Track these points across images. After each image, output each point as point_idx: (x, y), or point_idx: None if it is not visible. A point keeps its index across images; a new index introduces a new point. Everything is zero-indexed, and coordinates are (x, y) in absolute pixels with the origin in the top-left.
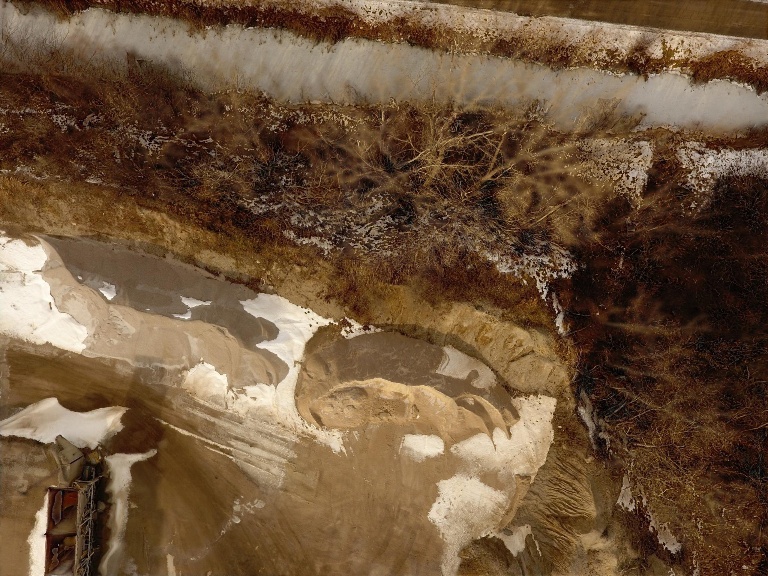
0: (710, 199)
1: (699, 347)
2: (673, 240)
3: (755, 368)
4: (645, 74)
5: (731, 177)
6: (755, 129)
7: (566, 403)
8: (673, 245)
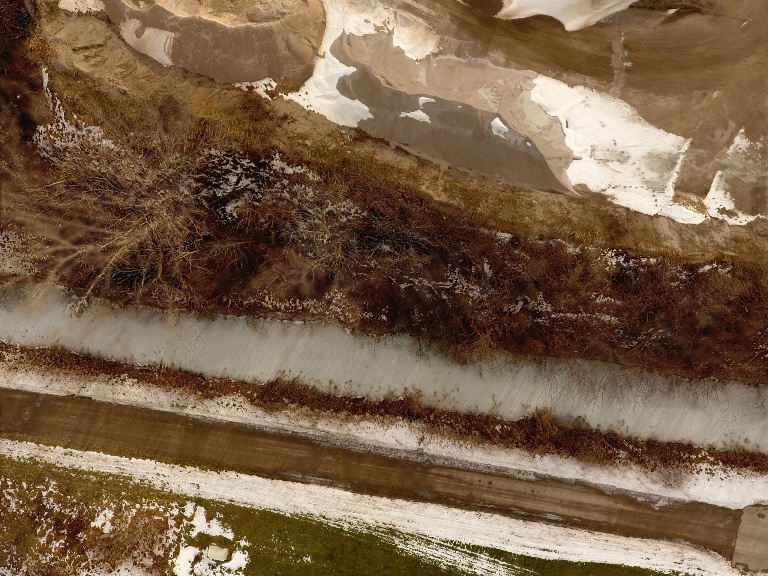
0: None
1: None
2: None
3: None
4: None
5: None
6: None
7: (47, 0)
8: None
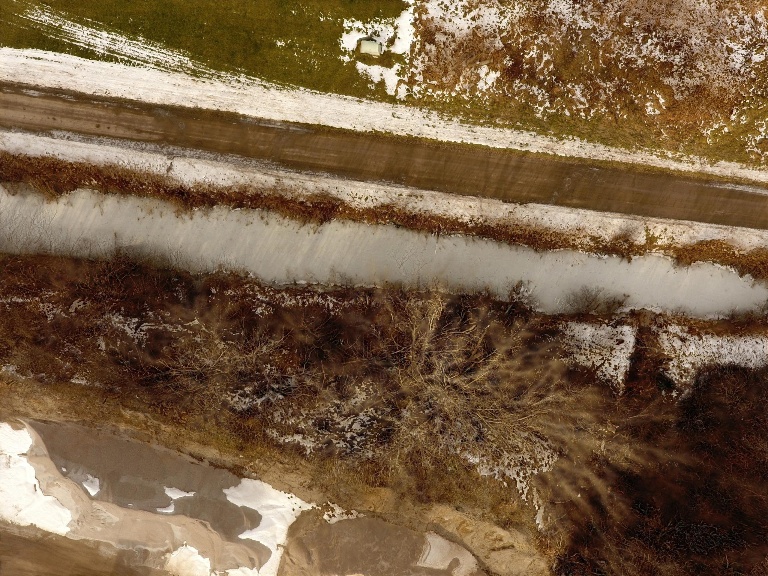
0: (691, 388)
1: (679, 531)
2: (654, 426)
3: (734, 559)
4: (628, 256)
5: (712, 364)
6: (737, 311)
7: None
8: (654, 430)
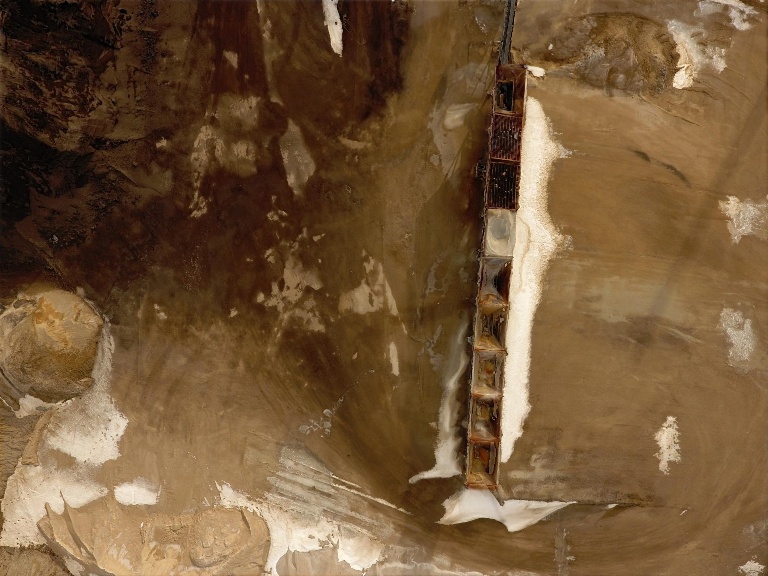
0: None
1: None
2: None
3: None
4: None
5: None
6: None
7: None
8: None
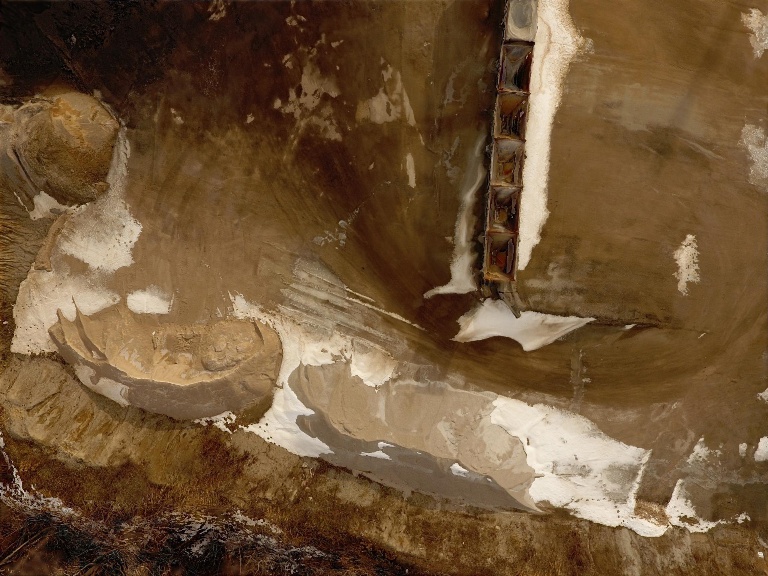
0: None
1: None
2: None
3: None
4: None
5: None
6: None
7: None
8: None
